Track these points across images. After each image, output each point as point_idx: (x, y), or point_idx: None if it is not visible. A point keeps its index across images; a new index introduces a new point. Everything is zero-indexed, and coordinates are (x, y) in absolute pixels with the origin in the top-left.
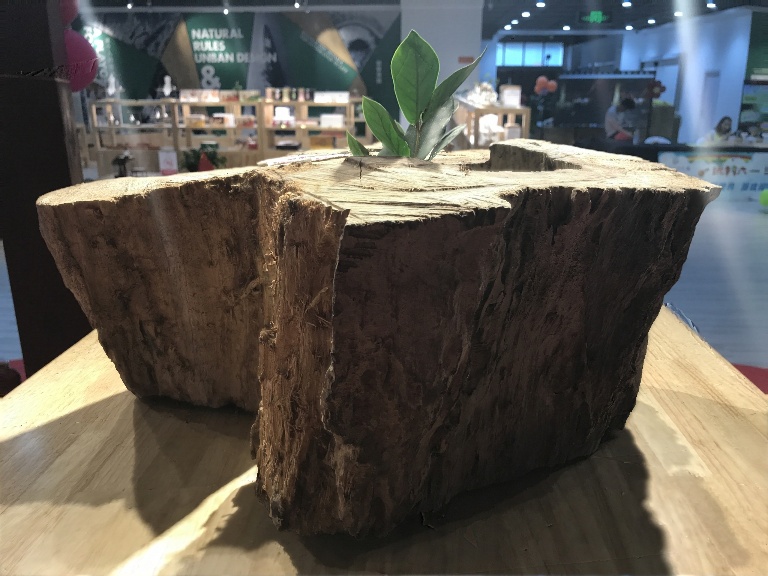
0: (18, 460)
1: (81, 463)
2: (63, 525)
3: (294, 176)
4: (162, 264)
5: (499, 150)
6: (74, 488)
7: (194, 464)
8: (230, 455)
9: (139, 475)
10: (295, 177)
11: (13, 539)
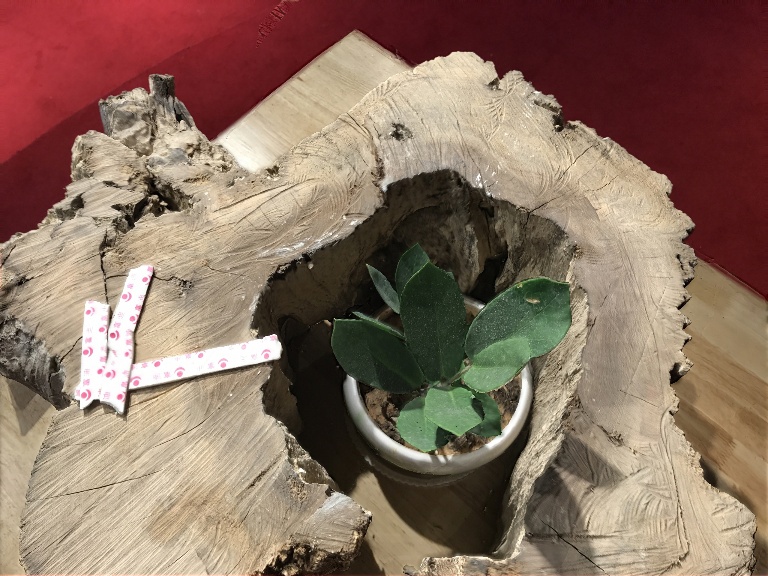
0: None
1: None
2: None
3: None
4: None
5: (396, 189)
6: None
7: None
8: None
9: None
10: None
11: None
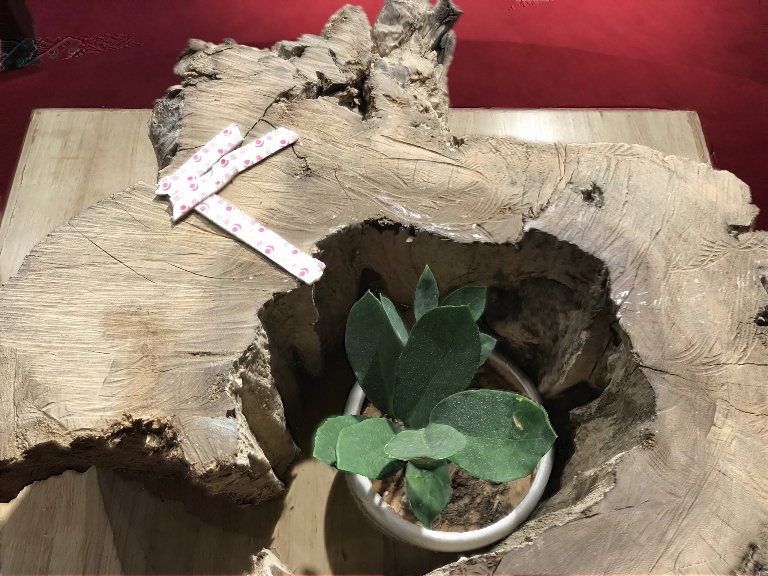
0: None
1: None
2: None
3: None
4: (79, 461)
5: (538, 238)
6: None
7: None
8: (220, 564)
9: None
10: None
11: None
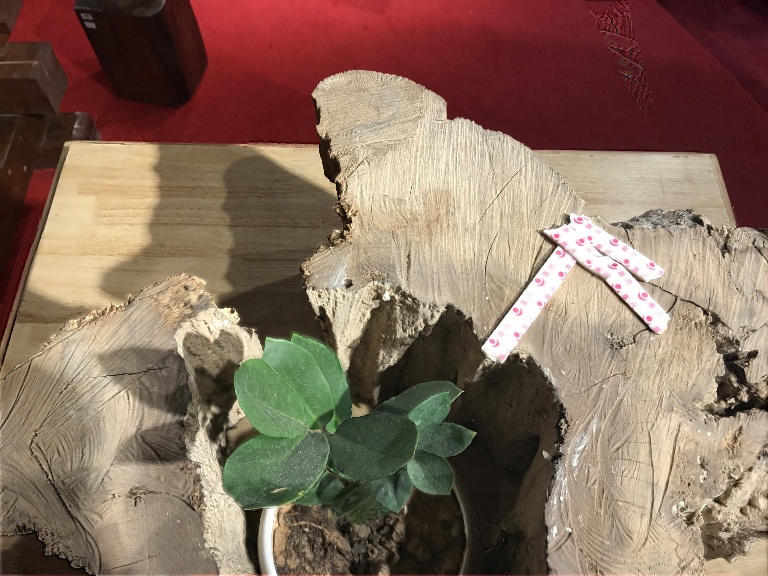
0: (285, 204)
1: (279, 245)
2: (206, 265)
3: (136, 310)
4: None
5: None
6: (247, 254)
7: (277, 323)
8: None
9: (262, 289)
10: (133, 311)
11: (196, 244)
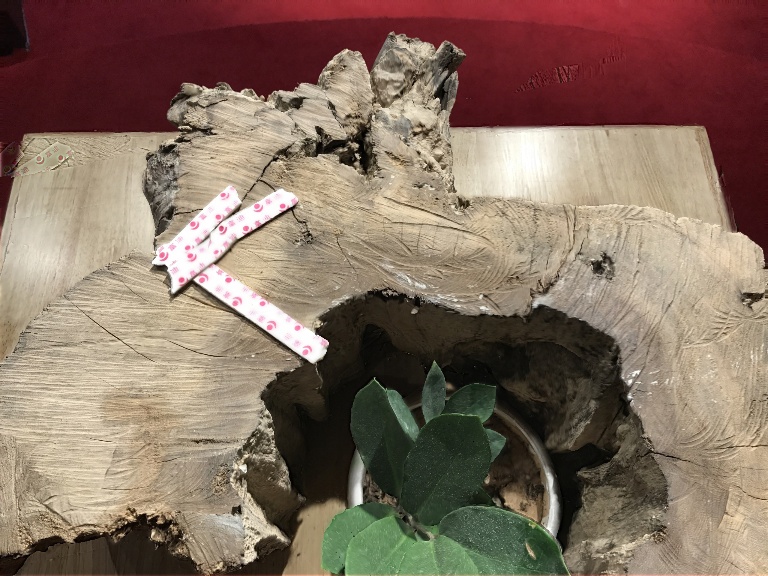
0: None
1: None
2: None
3: None
4: None
5: (547, 314)
6: None
7: None
8: None
9: None
10: None
11: None
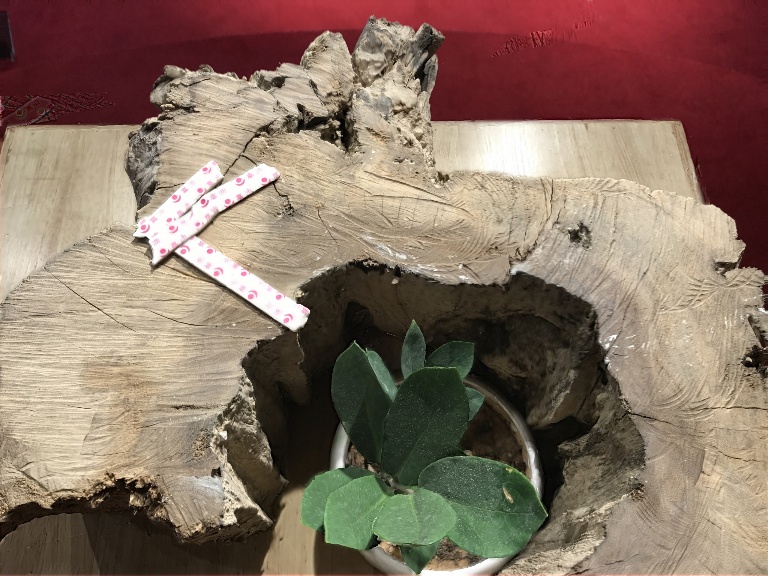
0: None
1: None
2: None
3: None
4: None
5: (525, 281)
6: None
7: None
8: None
9: None
10: None
11: None
